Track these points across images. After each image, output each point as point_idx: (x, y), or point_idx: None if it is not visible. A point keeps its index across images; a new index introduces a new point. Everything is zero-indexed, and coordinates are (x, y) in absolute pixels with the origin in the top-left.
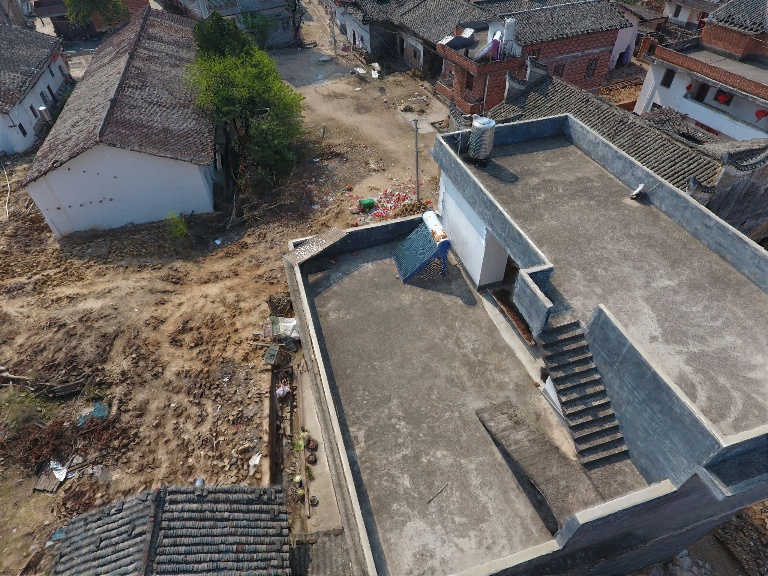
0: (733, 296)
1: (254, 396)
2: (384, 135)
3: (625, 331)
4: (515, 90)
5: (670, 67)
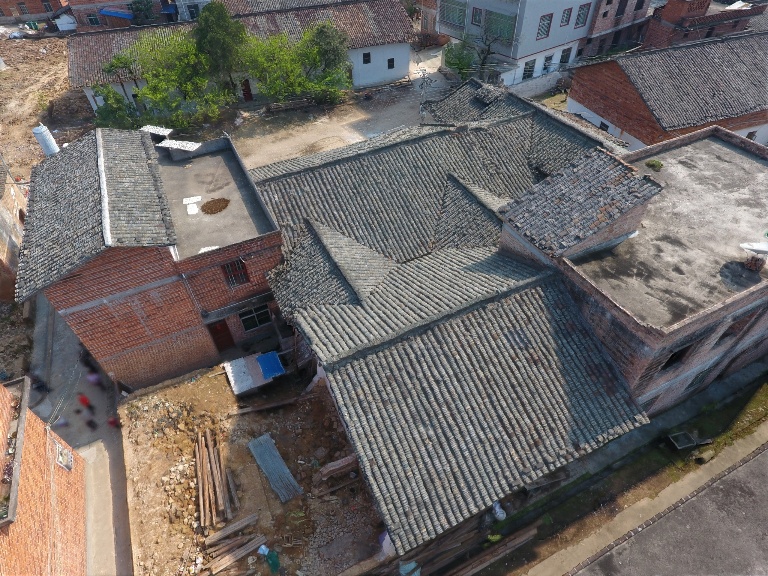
0: None
1: None
2: None
3: None
4: None
5: None
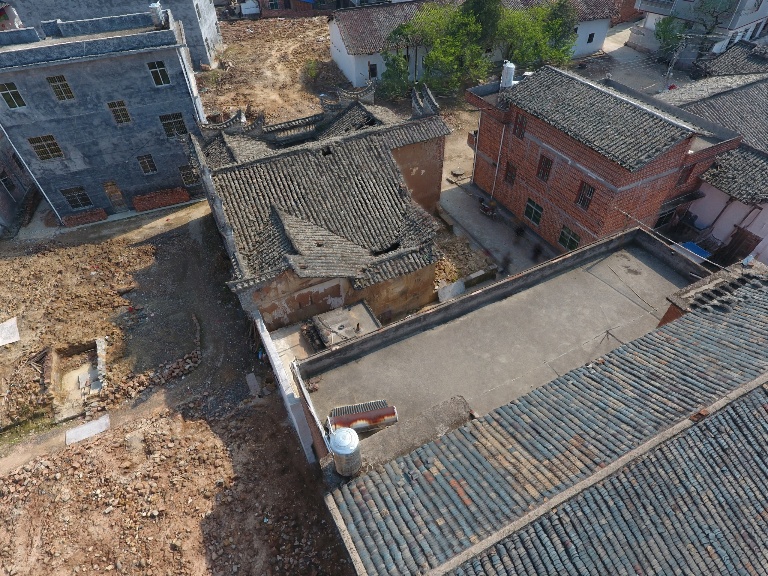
0: None
1: None
2: None
3: (20, 29)
4: None
5: None
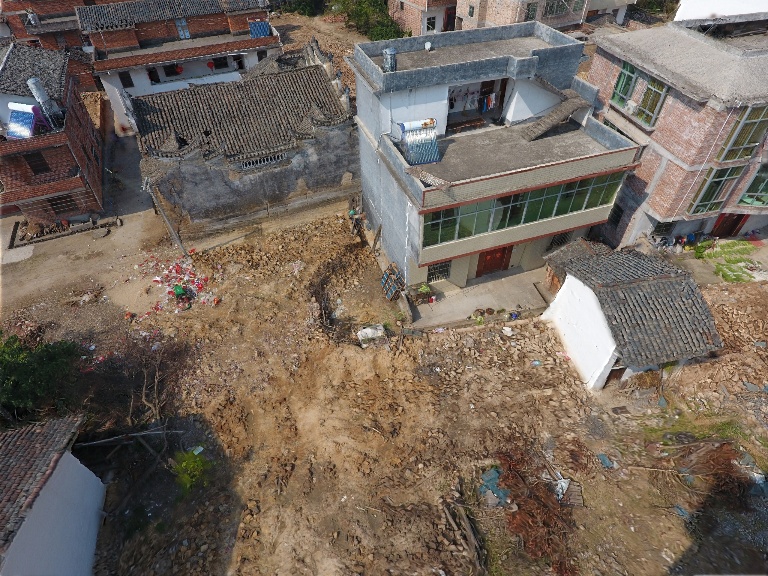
0: (496, 45)
1: (456, 339)
2: (4, 291)
3: None
4: (136, 122)
5: (125, 70)
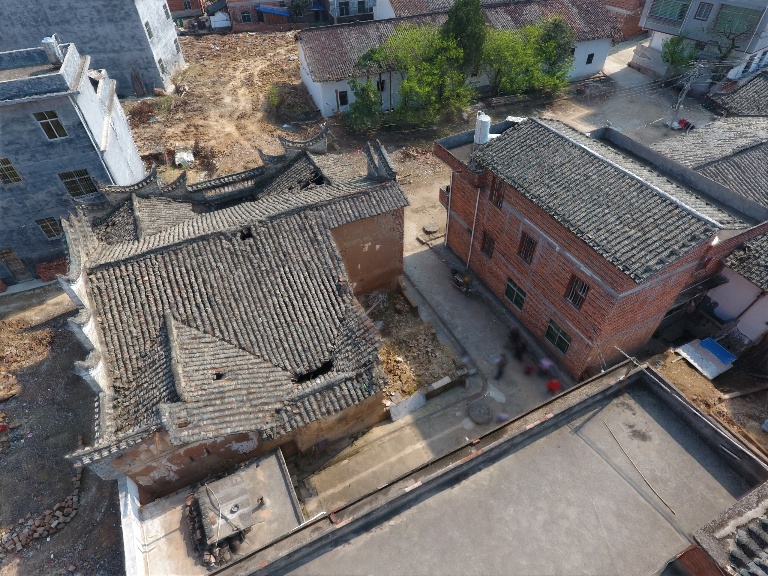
0: None
1: None
2: None
3: None
4: (372, 170)
5: None
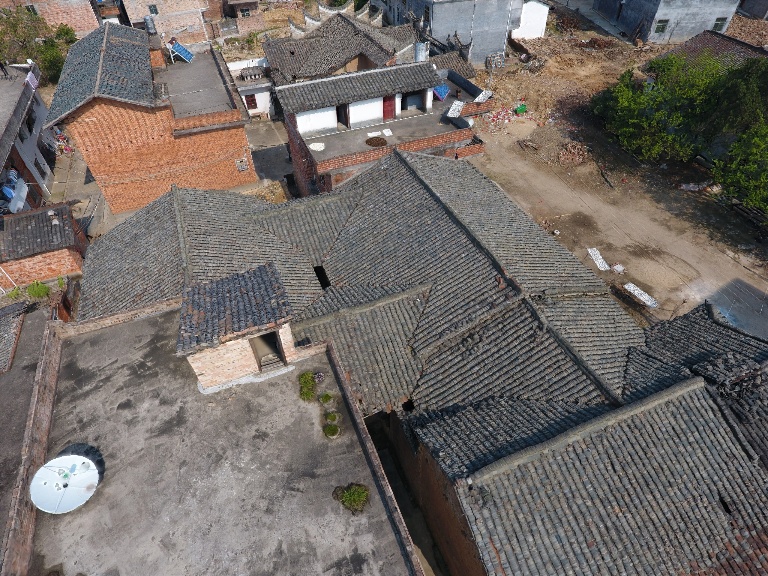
0: None
1: None
2: (534, 178)
3: None
4: None
5: None
